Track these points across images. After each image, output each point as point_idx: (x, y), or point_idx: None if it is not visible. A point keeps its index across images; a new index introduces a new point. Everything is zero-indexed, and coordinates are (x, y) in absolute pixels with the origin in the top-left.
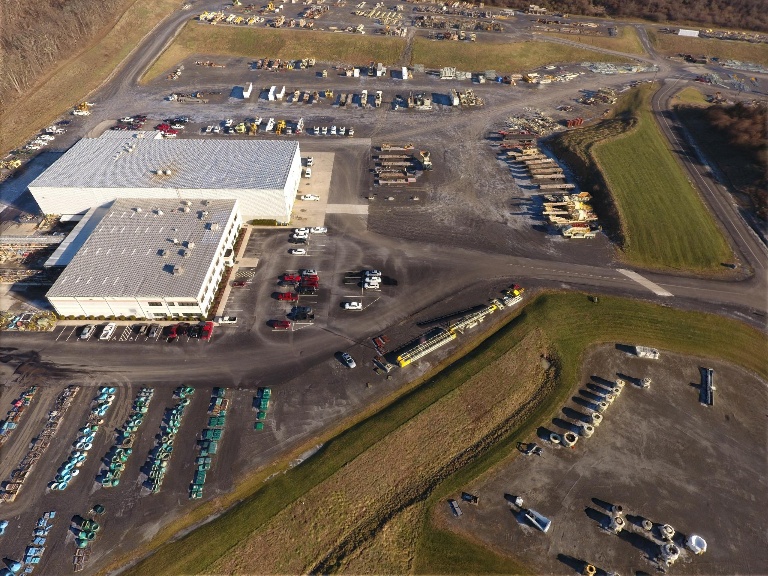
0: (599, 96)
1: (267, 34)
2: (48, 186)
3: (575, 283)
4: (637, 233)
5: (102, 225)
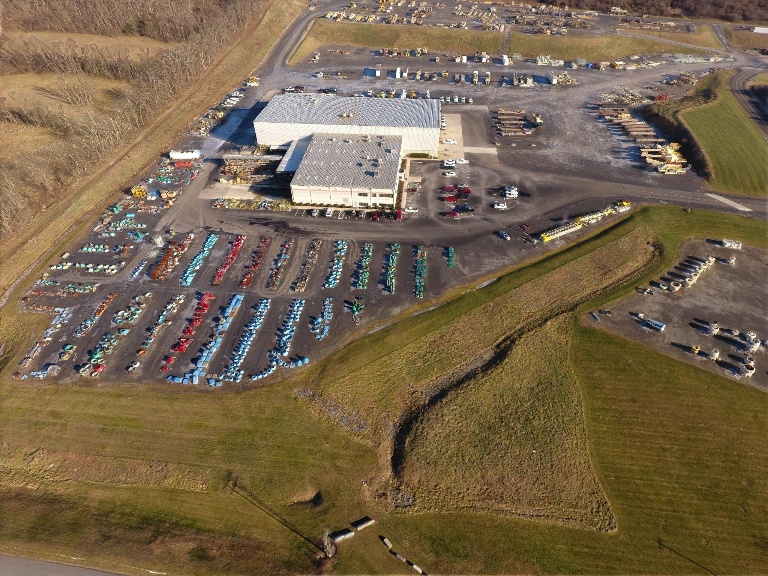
0: (681, 79)
1: (384, 29)
2: (268, 122)
3: (671, 201)
4: (721, 171)
5: (311, 148)
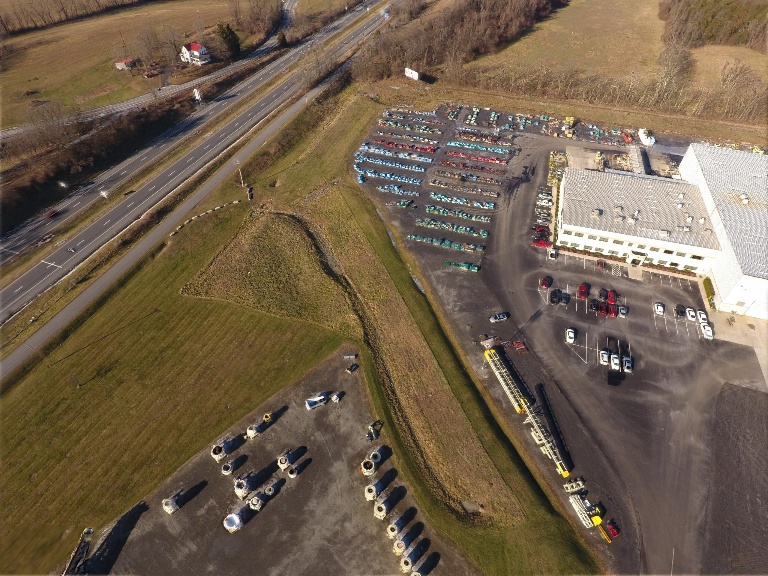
0: None
1: None
2: (695, 150)
3: None
4: None
5: (654, 181)
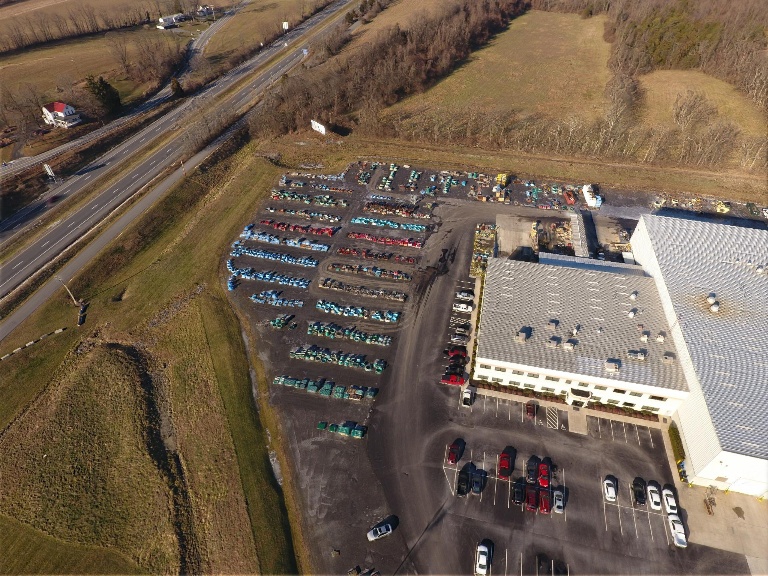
0: None
1: None
2: (647, 225)
3: None
4: None
5: (598, 274)
